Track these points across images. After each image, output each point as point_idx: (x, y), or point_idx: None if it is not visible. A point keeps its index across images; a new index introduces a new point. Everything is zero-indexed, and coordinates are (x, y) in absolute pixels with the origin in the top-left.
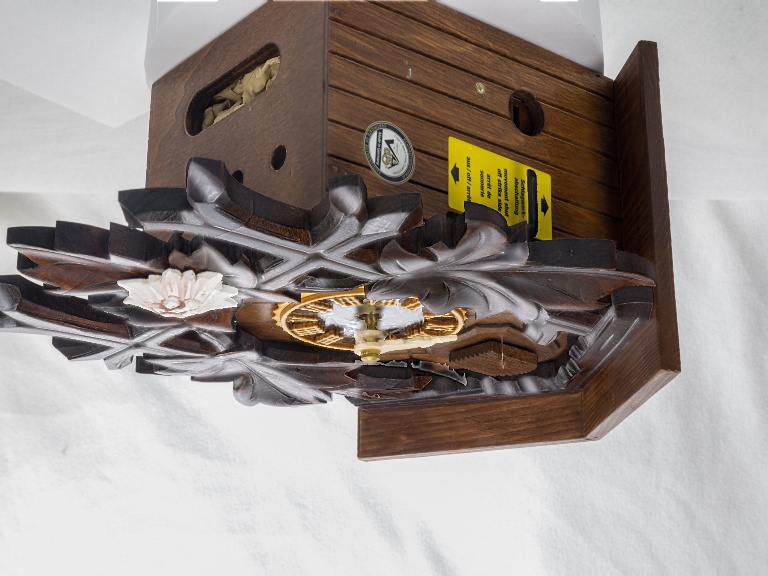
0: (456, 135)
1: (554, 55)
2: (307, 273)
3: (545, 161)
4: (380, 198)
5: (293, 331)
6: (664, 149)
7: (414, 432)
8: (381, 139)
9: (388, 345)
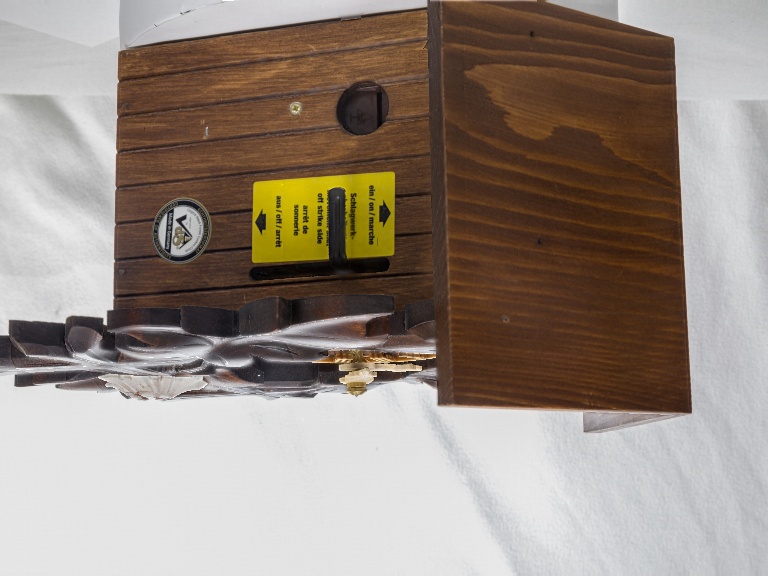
0: (264, 177)
1: (407, 14)
2: None
3: (388, 156)
4: None
5: (340, 362)
6: (443, 117)
7: None
8: (172, 220)
9: (348, 380)
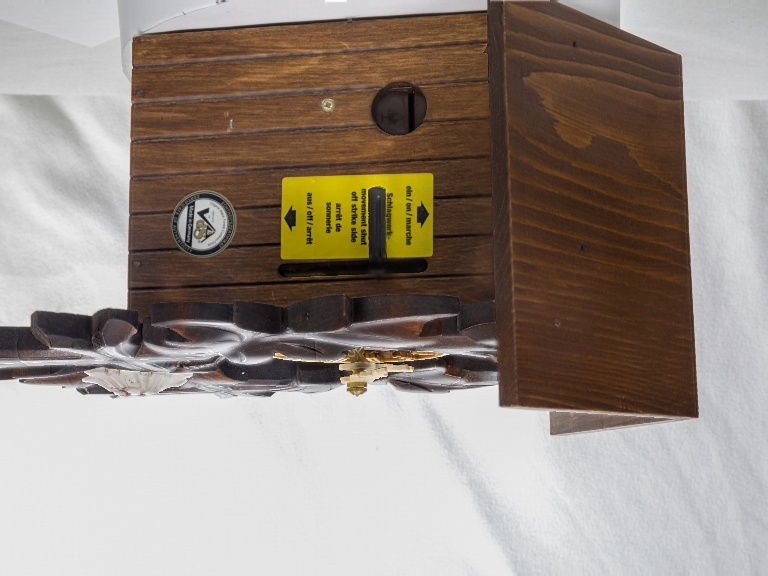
0: (293, 173)
1: (446, 17)
2: None
3: (426, 158)
4: (93, 316)
5: (326, 361)
6: (506, 122)
7: None
8: (193, 213)
9: None
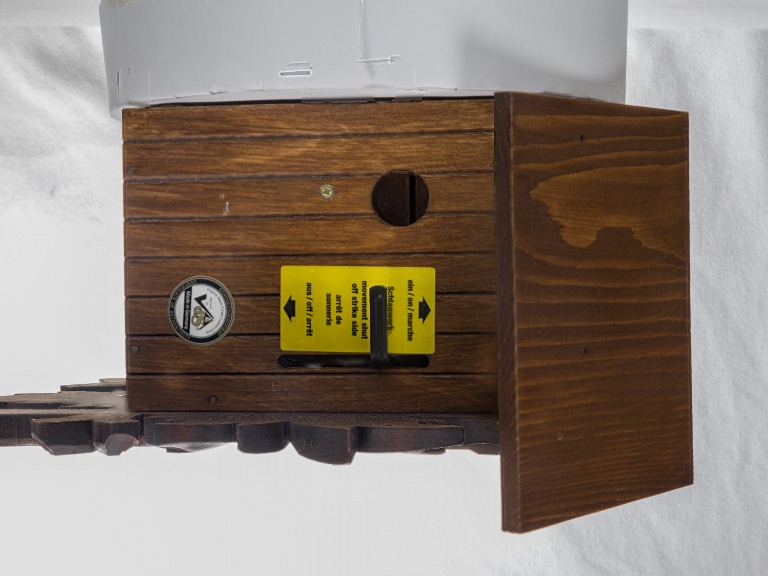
0: (292, 261)
1: (449, 103)
2: None
3: (428, 251)
4: (94, 423)
5: None
6: (513, 245)
7: None
8: (190, 298)
9: None
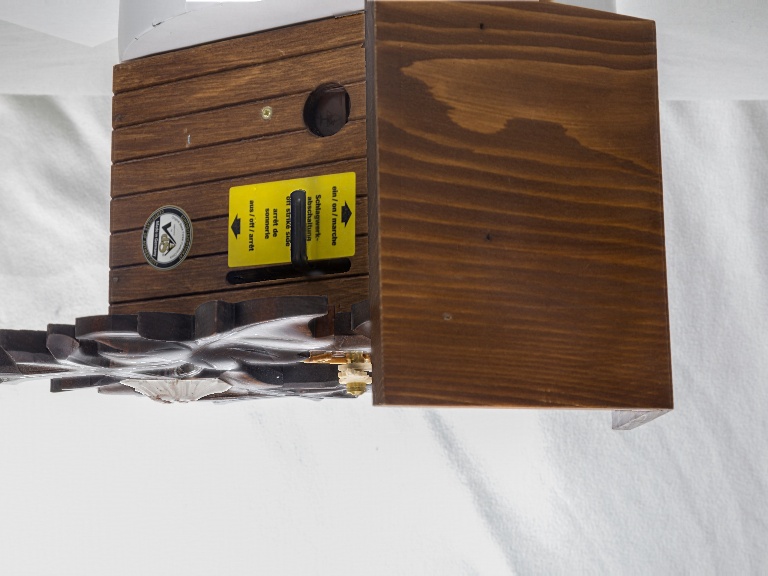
0: (239, 182)
1: None
2: None
3: (350, 157)
4: None
5: None
6: (376, 116)
7: None
8: (159, 228)
9: None
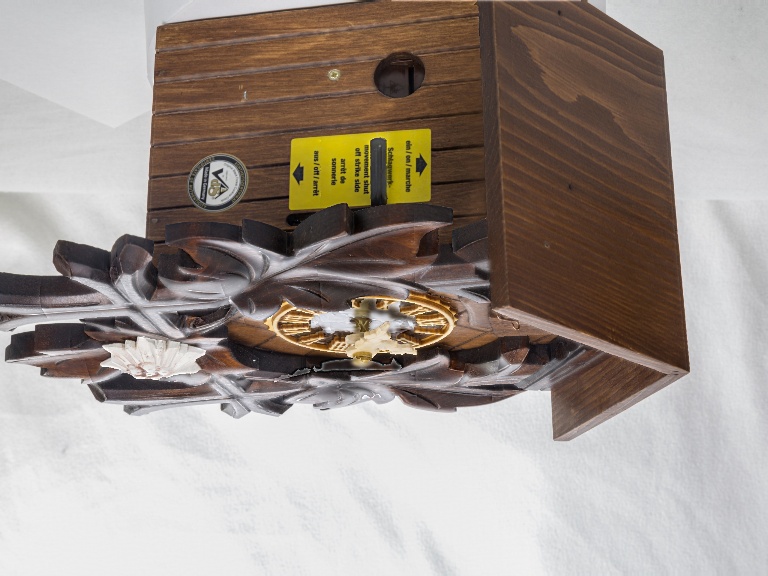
0: (302, 134)
1: None
2: (187, 316)
3: (424, 116)
4: None
5: (334, 350)
6: (495, 59)
7: (577, 403)
8: (208, 173)
9: (359, 346)
